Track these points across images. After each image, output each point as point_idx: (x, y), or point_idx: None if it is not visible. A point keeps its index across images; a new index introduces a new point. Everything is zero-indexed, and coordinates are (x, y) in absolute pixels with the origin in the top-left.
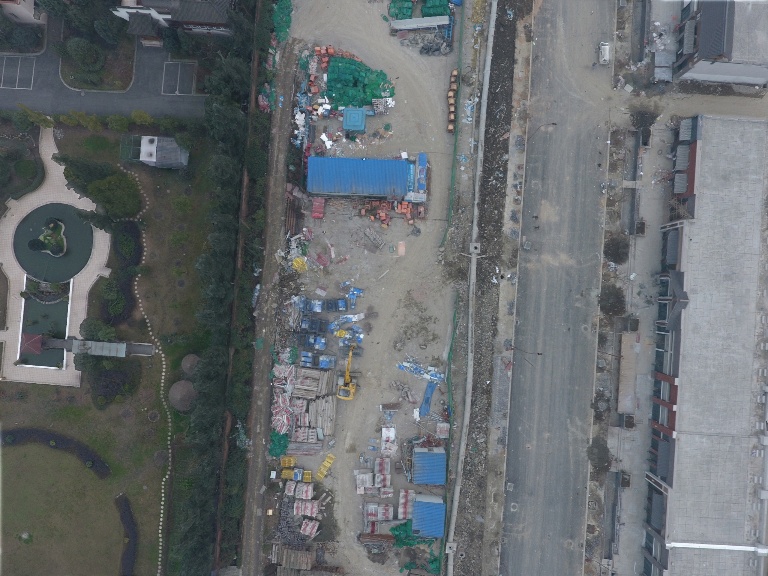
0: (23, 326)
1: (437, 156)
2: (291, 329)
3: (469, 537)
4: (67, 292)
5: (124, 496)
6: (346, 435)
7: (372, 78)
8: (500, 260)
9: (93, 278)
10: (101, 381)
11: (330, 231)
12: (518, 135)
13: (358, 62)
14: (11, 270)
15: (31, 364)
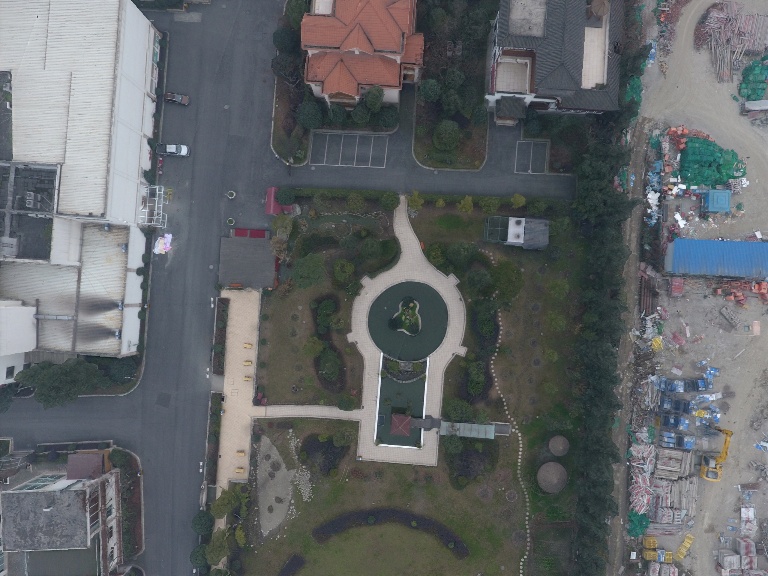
0: (379, 405)
1: None
2: (647, 408)
3: None
4: (423, 371)
5: None
6: (704, 515)
7: (729, 158)
8: None
9: (448, 357)
10: (462, 461)
11: (685, 310)
12: None
13: (714, 142)
14: (366, 349)
15: (388, 443)
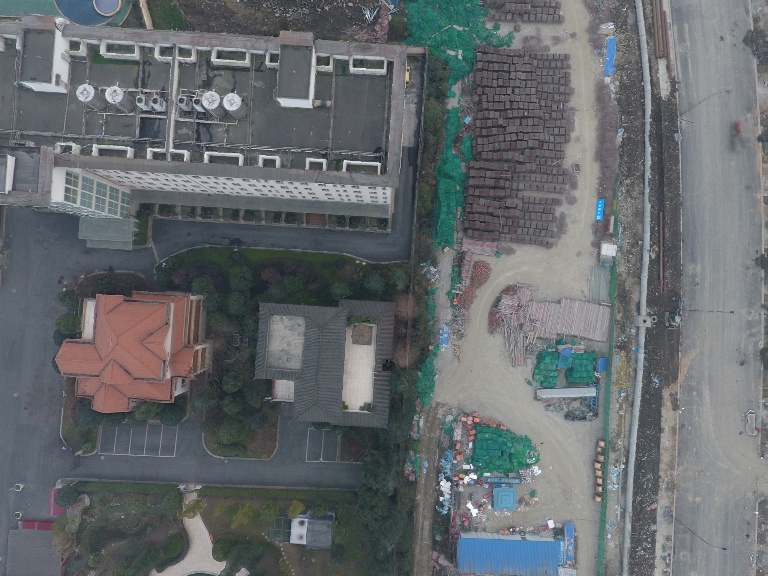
0: None
1: (583, 523)
2: None
3: None
4: None
5: None
6: None
7: (519, 449)
8: None
9: None
10: None
11: None
12: (666, 506)
13: (504, 432)
14: None
15: None
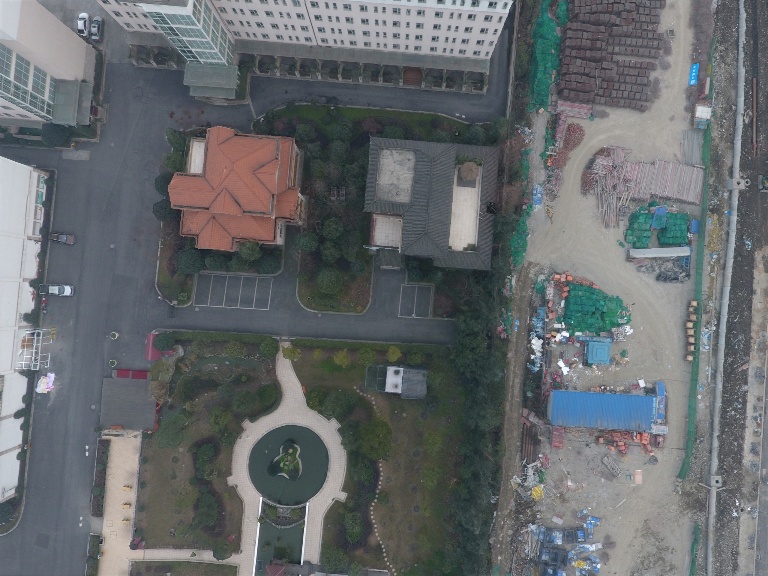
0: (258, 550)
1: (674, 384)
2: (527, 557)
3: None
4: (302, 516)
5: None
6: None
7: (612, 307)
8: (740, 493)
9: (328, 502)
10: None
11: (566, 458)
12: (757, 366)
13: (597, 290)
14: (246, 492)
15: None
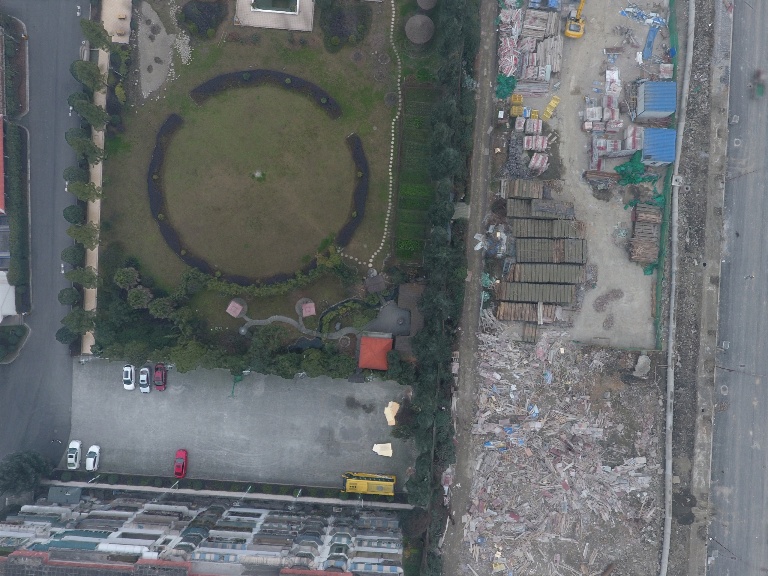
0: None
1: None
2: None
3: (693, 173)
4: None
5: (356, 135)
6: (571, 78)
7: None
8: None
9: None
10: (335, 22)
11: None
12: None
13: None
14: None
15: (265, 9)
